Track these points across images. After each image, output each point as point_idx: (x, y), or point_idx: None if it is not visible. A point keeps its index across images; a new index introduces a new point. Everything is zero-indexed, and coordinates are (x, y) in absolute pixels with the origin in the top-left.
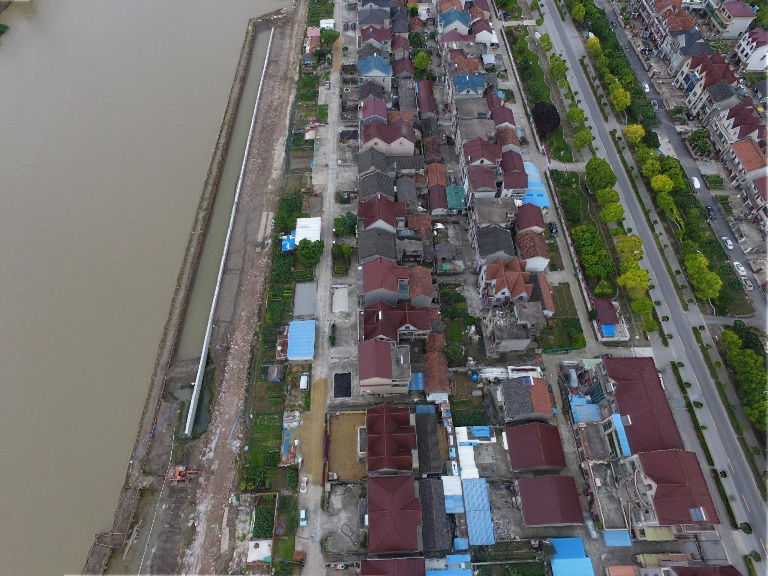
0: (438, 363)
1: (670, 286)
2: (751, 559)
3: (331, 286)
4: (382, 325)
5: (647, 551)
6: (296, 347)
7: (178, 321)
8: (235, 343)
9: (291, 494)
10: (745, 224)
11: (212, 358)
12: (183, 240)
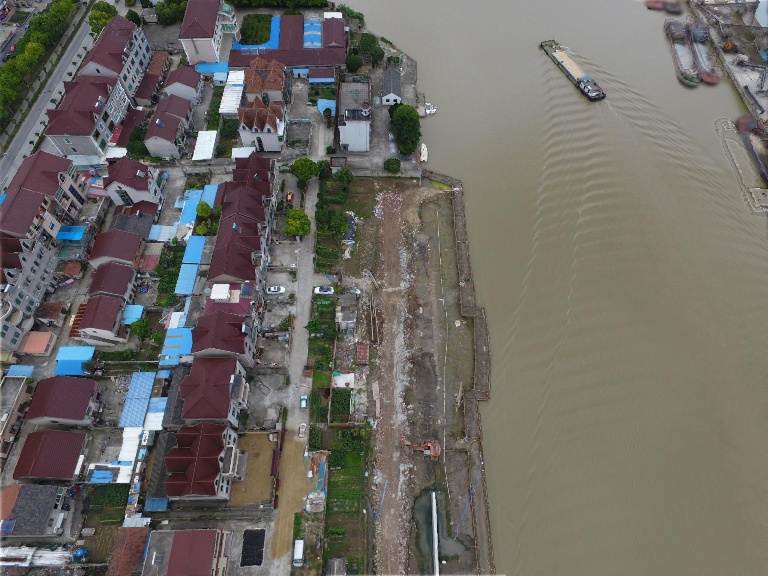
0: (117, 569)
1: None
2: None
3: None
4: None
5: (3, 366)
6: None
7: None
8: None
9: (317, 424)
10: None
11: None
12: None
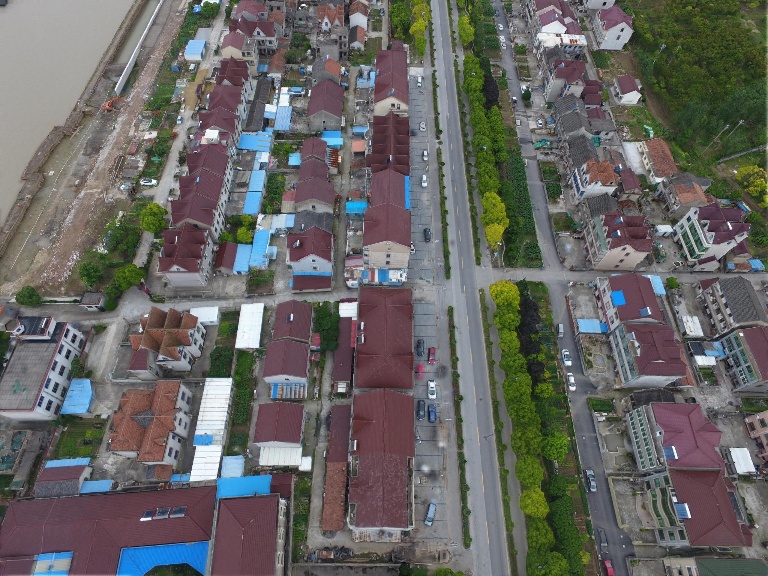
0: (278, 58)
1: (449, 42)
2: (442, 150)
3: (222, 29)
4: (240, 25)
5: None
6: (190, 50)
7: (118, 44)
8: (153, 55)
9: (175, 114)
10: (518, 19)
11: (138, 64)
12: (127, 7)
